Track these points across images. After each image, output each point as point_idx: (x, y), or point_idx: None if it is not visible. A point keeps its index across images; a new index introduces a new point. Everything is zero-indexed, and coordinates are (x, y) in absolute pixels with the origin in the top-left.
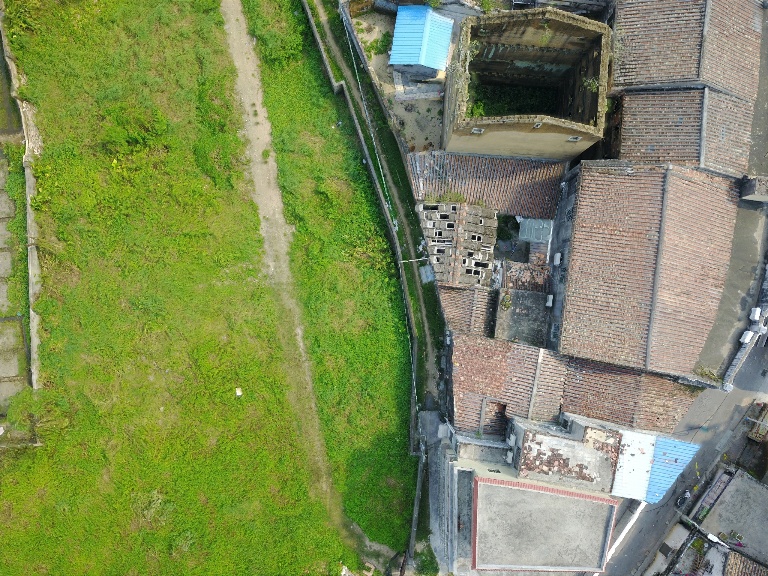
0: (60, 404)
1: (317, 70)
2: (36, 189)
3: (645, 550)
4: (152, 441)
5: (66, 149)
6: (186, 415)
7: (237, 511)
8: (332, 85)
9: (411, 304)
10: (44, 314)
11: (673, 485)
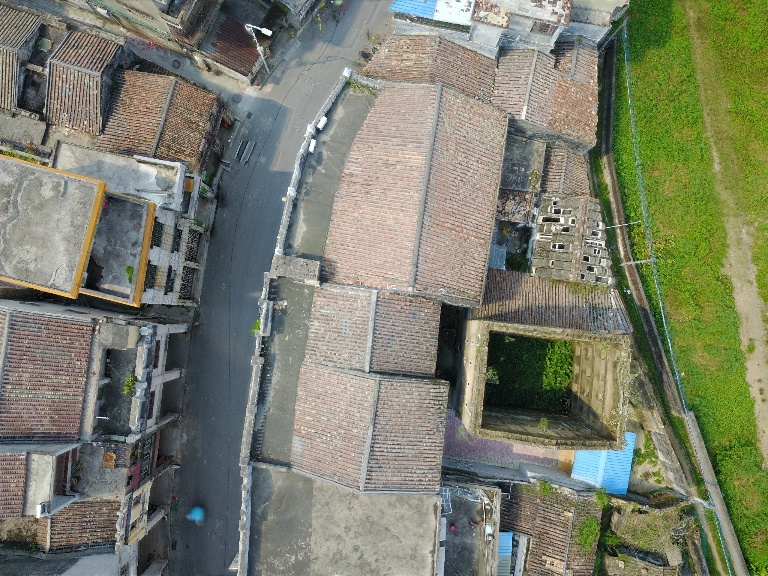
0: None
1: None
2: None
3: None
4: None
5: None
6: None
7: None
8: None
9: (610, 188)
10: None
11: (344, 8)
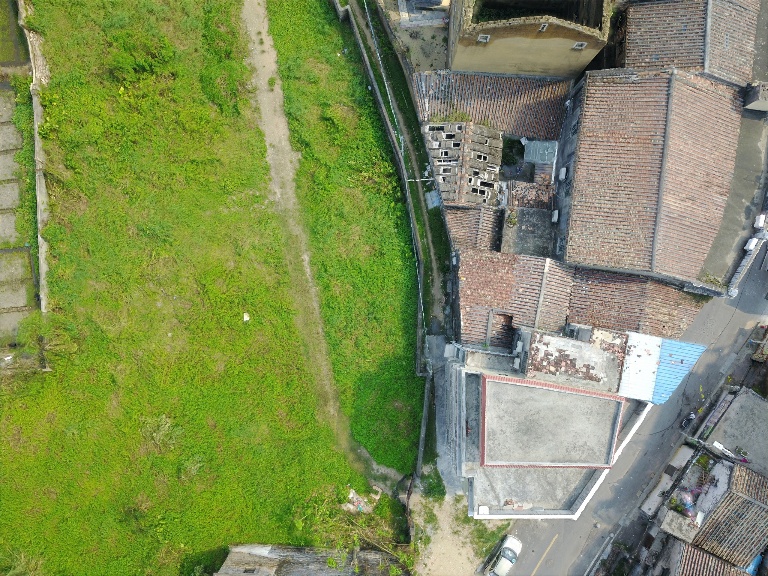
0: (69, 328)
1: None
2: (43, 118)
3: (650, 472)
4: (160, 366)
5: (73, 77)
6: (194, 340)
7: (245, 434)
8: (337, 11)
9: (417, 228)
10: (52, 241)
11: (678, 408)
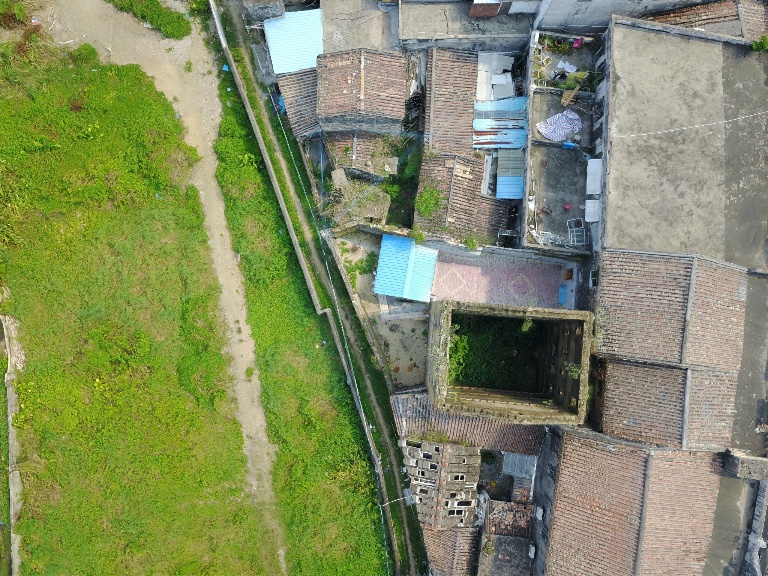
0: None
1: (301, 289)
2: (18, 404)
3: None
4: None
5: (48, 367)
6: None
7: None
8: None
9: (394, 531)
10: (25, 534)
11: None
